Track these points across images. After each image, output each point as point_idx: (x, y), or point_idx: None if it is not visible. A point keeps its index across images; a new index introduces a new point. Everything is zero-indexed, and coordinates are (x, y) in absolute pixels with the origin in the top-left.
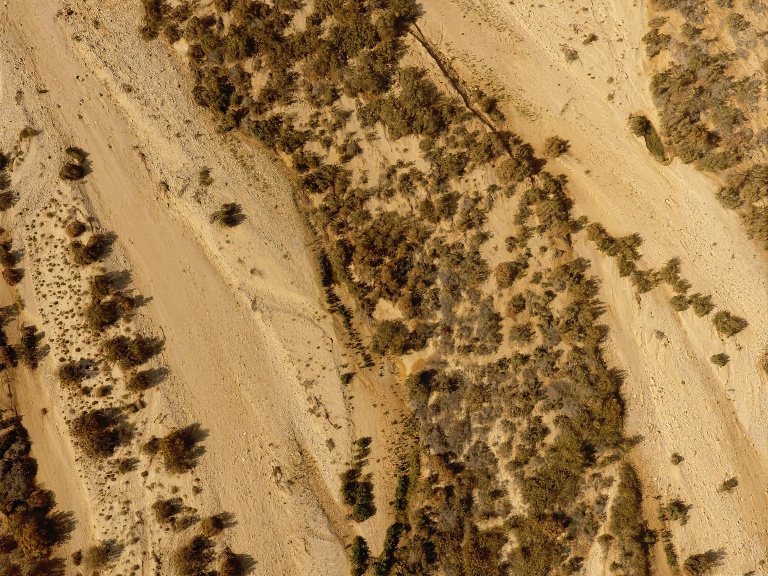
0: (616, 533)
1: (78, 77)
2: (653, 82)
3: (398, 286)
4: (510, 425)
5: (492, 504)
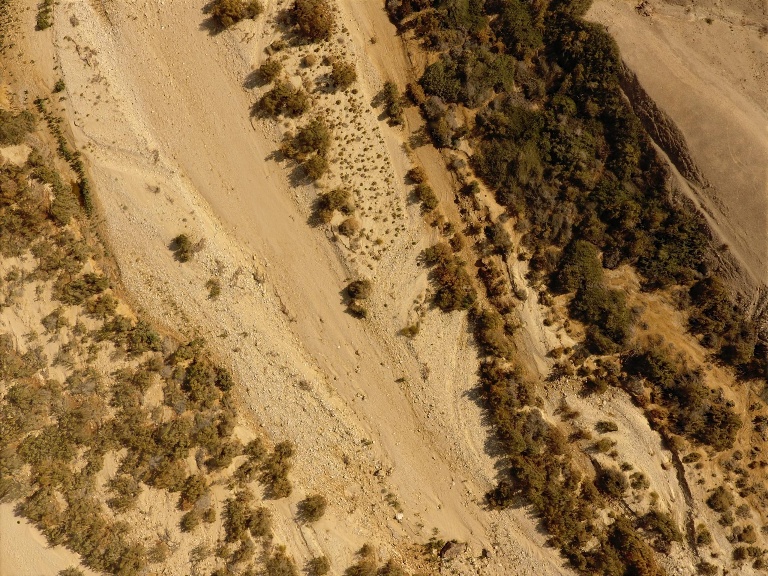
0: None
1: (363, 398)
2: None
3: None
4: None
5: None
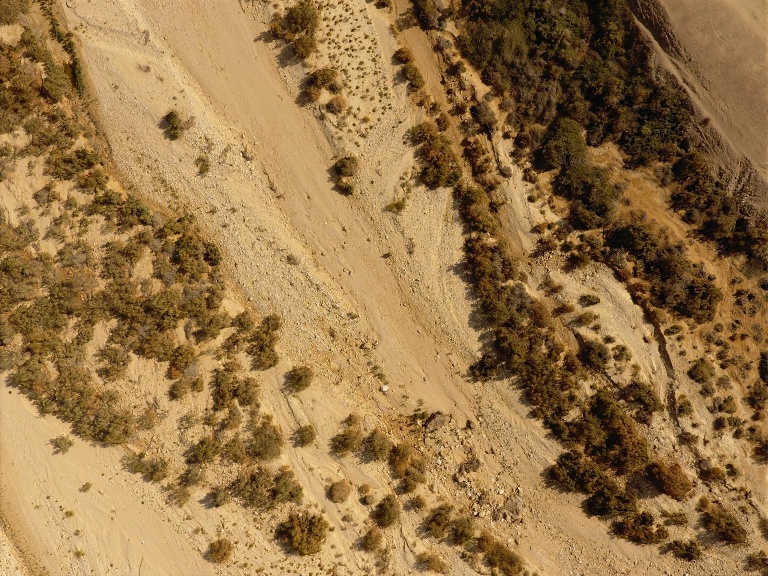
0: None
1: (350, 273)
2: None
3: None
4: None
5: None
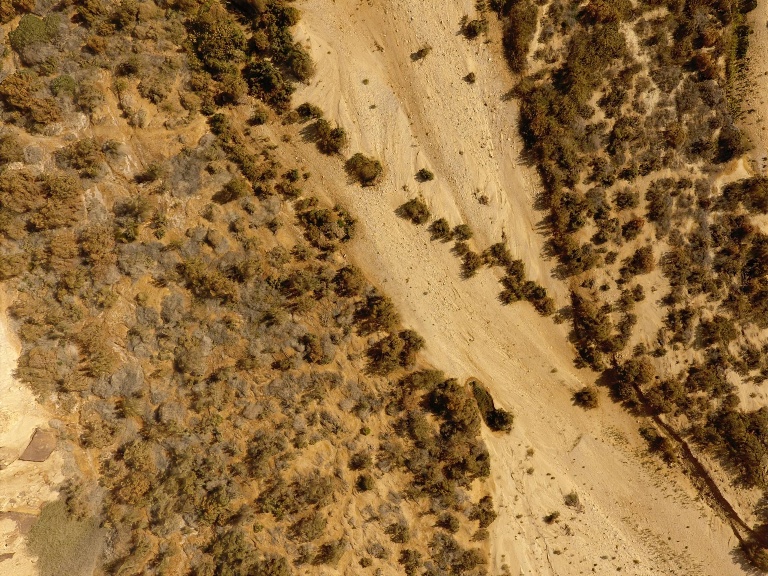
0: (535, 6)
1: None
2: None
3: (760, 249)
4: (639, 109)
5: (654, 32)
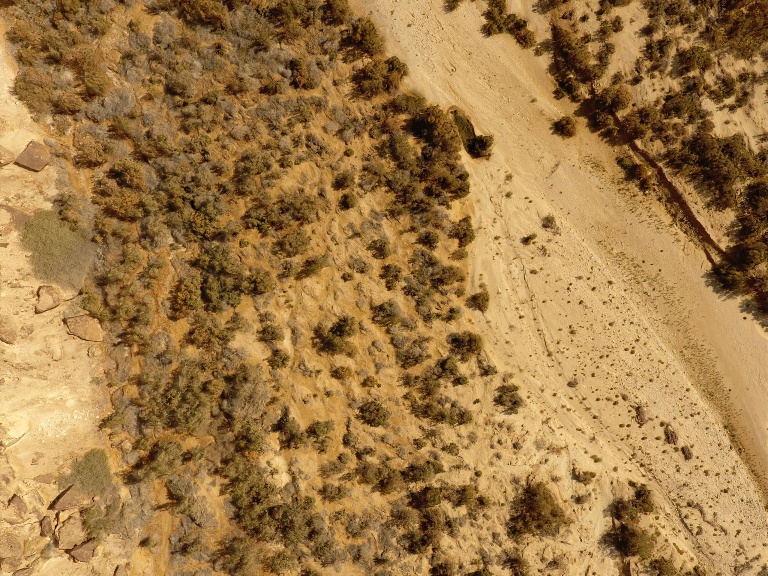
0: None
1: None
2: None
3: None
4: None
5: None
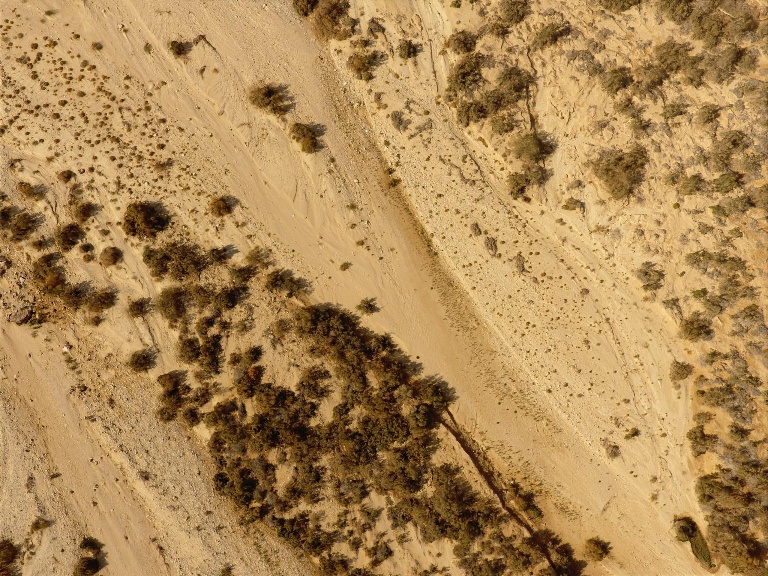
0: None
1: (92, 460)
2: (699, 488)
3: None
4: None
5: None
